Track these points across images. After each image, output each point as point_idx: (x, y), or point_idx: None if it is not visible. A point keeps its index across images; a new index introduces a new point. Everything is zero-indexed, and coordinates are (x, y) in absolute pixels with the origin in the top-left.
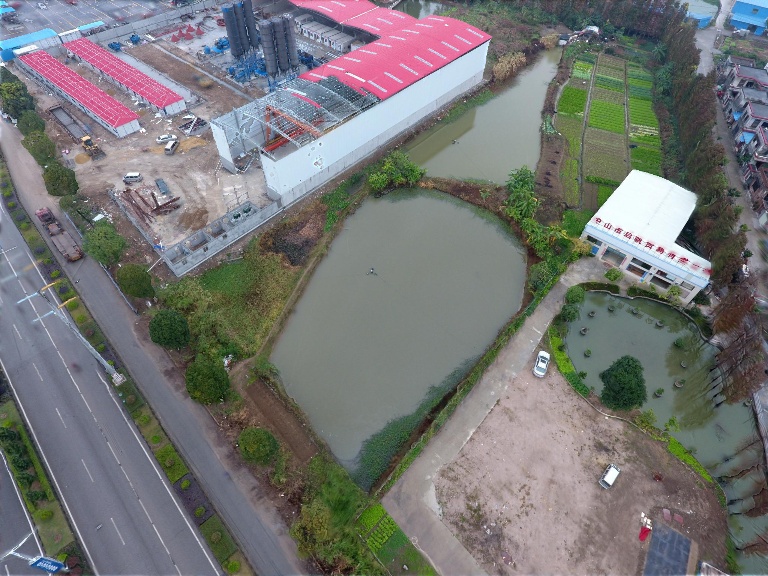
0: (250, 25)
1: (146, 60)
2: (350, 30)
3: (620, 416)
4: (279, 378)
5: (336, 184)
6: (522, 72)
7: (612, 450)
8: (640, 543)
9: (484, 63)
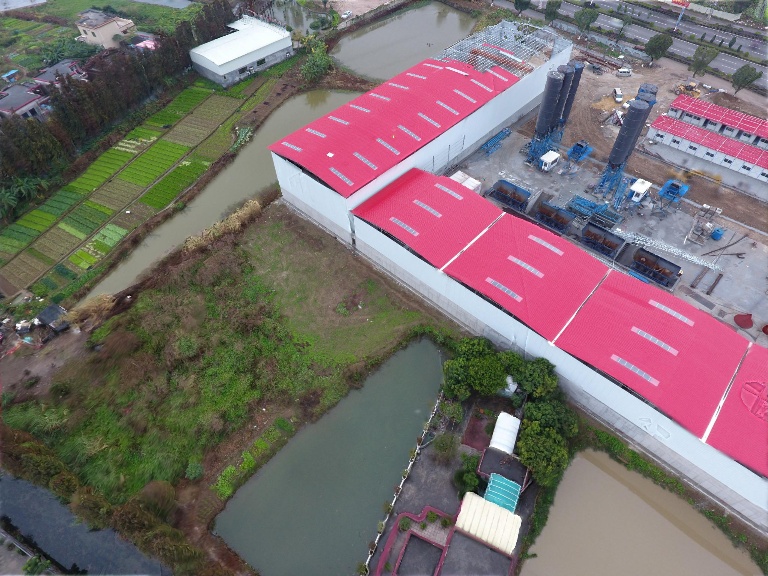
0: None
1: None
2: None
3: None
4: None
5: None
6: None
7: None
8: None
9: None
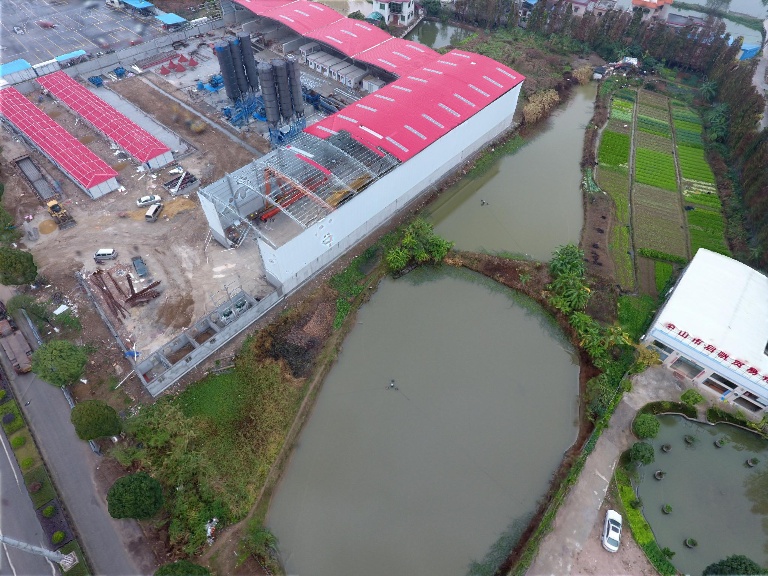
0: (248, 63)
1: (131, 97)
2: (362, 63)
3: None
4: (277, 553)
5: (347, 261)
6: (555, 112)
7: None
8: None
9: (515, 106)
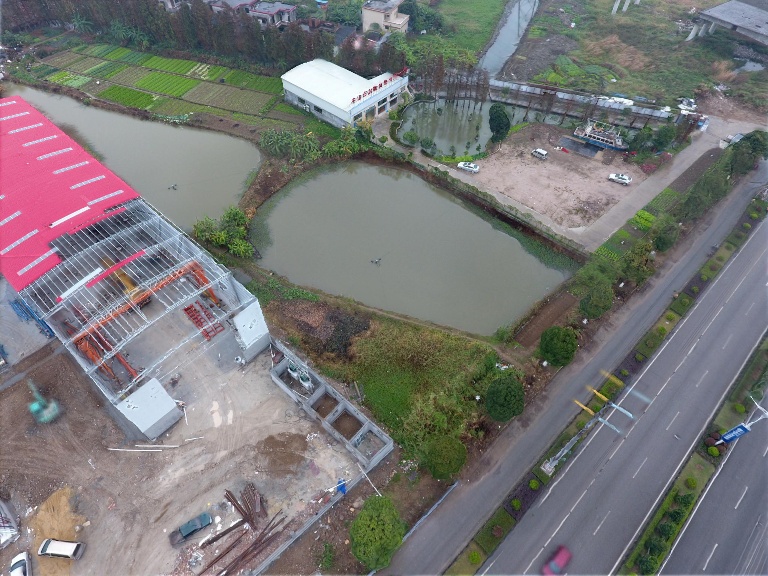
0: None
1: None
2: None
3: (499, 143)
4: None
5: None
6: None
7: (521, 152)
8: (570, 153)
9: None
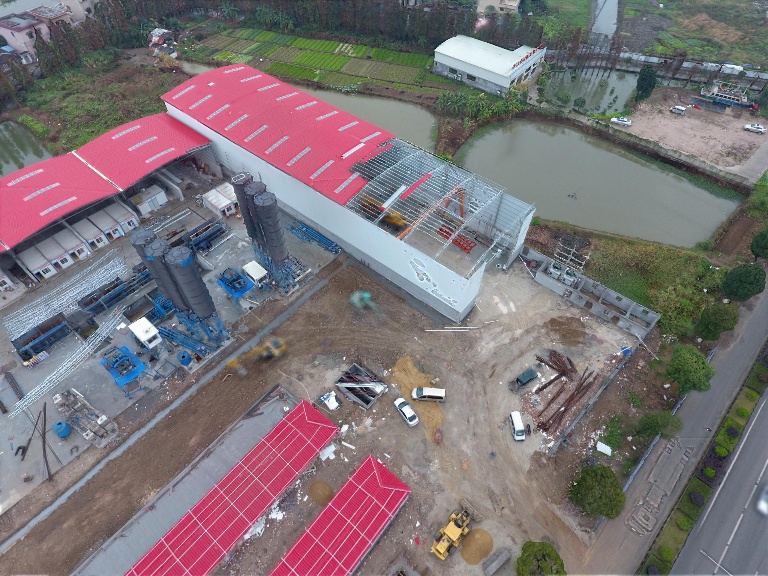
0: None
1: None
2: None
3: (638, 103)
4: None
5: None
6: None
7: (660, 109)
8: (702, 110)
9: None
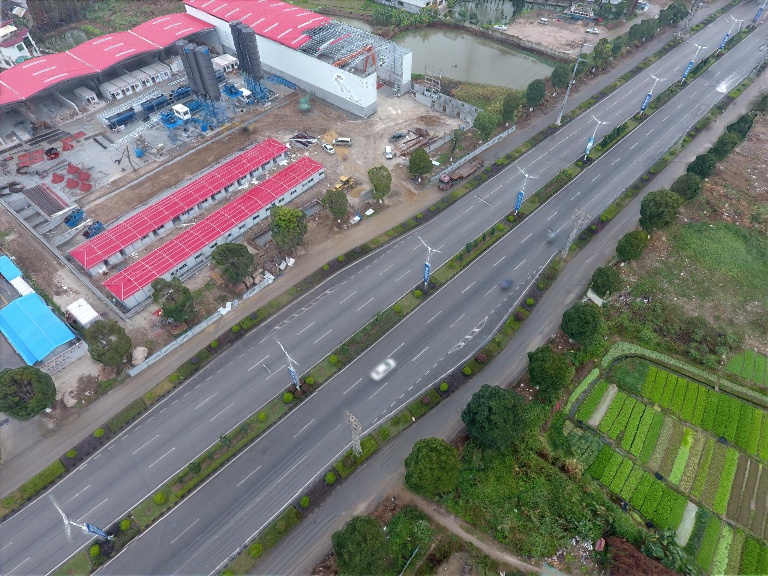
0: None
1: (141, 200)
2: (151, 58)
3: (517, 18)
4: None
5: None
6: None
7: None
8: (562, 22)
9: None
